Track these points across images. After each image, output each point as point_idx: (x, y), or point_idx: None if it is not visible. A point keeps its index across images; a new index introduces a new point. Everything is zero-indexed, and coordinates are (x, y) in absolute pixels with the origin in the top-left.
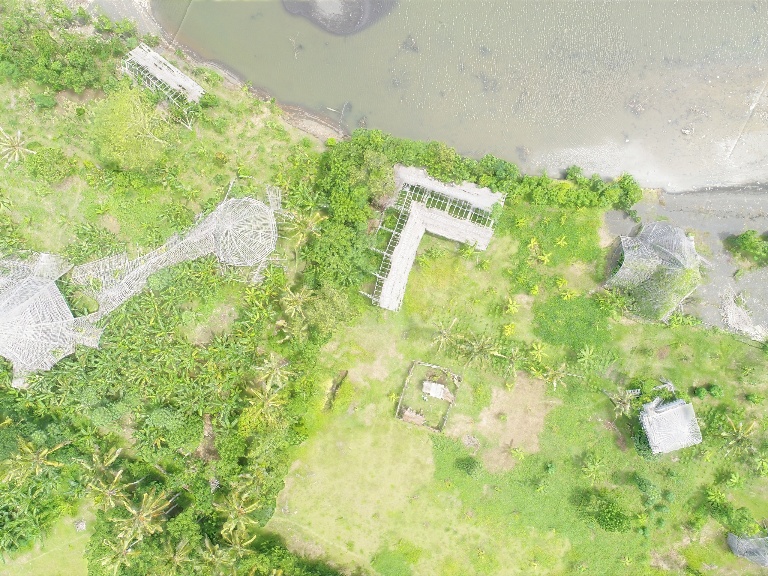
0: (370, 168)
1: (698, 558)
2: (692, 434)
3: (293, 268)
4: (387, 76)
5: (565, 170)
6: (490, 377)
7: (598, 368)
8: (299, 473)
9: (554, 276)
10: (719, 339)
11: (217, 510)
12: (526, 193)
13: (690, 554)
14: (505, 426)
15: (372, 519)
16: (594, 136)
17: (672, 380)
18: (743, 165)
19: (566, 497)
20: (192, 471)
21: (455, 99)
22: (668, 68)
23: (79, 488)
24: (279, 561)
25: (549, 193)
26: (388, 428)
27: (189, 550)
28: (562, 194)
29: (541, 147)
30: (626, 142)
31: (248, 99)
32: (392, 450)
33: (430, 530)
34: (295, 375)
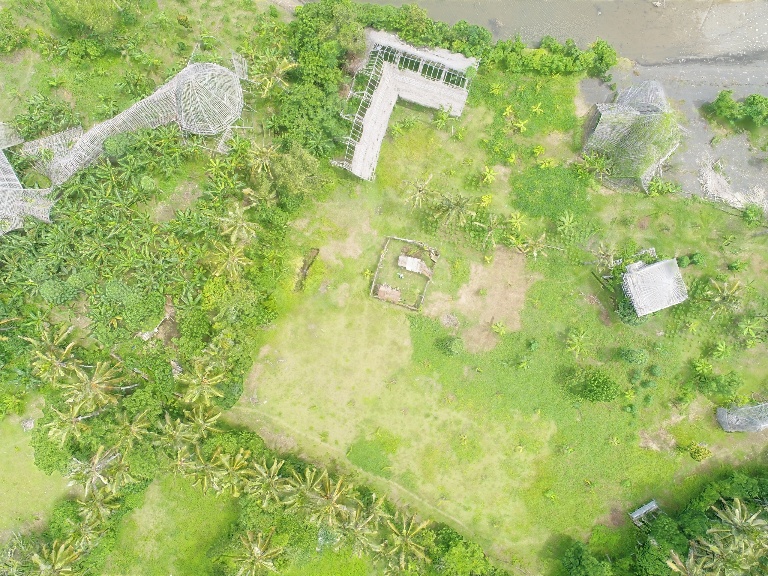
0: (340, 25)
1: (688, 436)
2: (677, 288)
3: (260, 142)
4: None
5: (538, 43)
6: (468, 252)
7: (578, 240)
8: (268, 359)
9: (531, 146)
10: (699, 208)
11: (179, 399)
12: (500, 60)
13: (679, 432)
14: (485, 303)
15: (347, 407)
16: (566, 9)
17: None
18: (714, 37)
19: (550, 376)
20: (151, 346)
21: None
22: None
23: (26, 377)
24: (247, 443)
25: (523, 58)
26: (363, 308)
27: (147, 424)
28: (536, 58)
29: (514, 20)
30: (598, 15)
31: None
32: (367, 332)
33: (409, 417)
34: (263, 248)
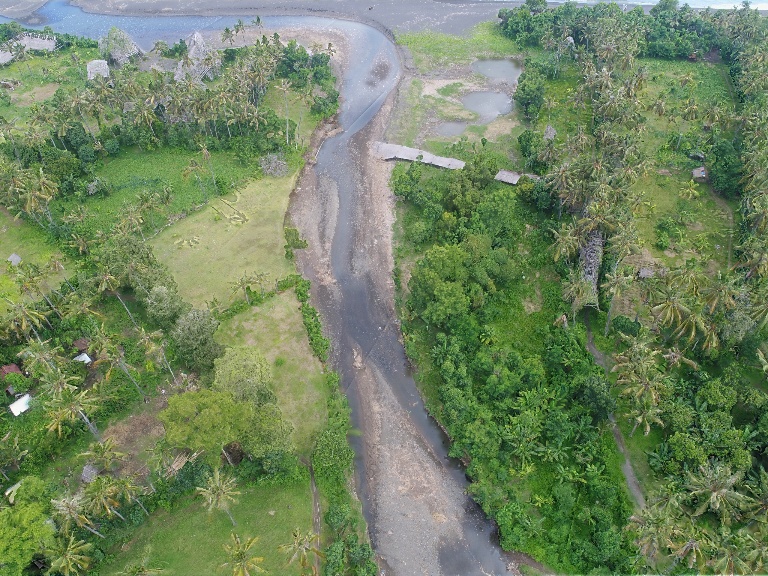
0: None
1: None
2: (100, 63)
3: None
4: None
5: None
6: (36, 84)
7: None
8: None
9: None
10: None
11: None
12: None
13: None
14: None
15: None
16: None
17: None
18: None
19: None
20: None
21: None
22: None
23: None
24: None
25: None
26: None
27: None
28: None
29: None
30: None
31: None
32: None
33: None
34: None
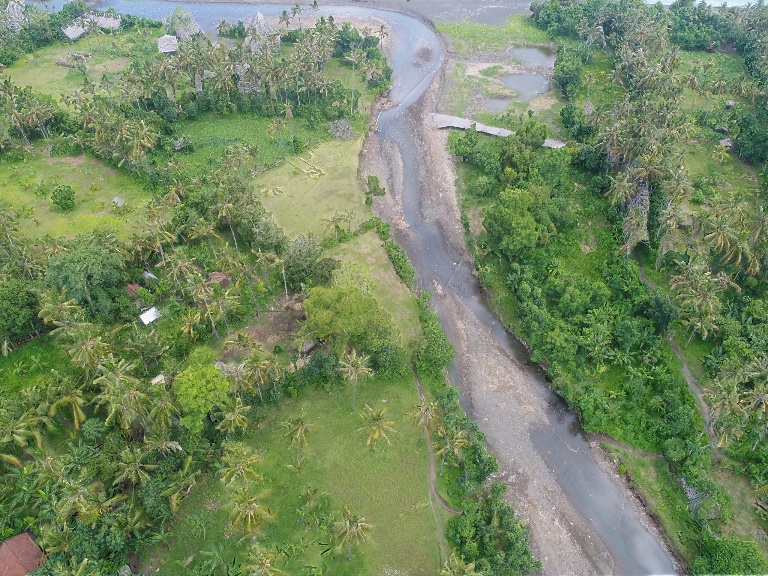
0: None
1: None
2: (171, 38)
3: None
4: None
5: None
6: None
7: None
8: None
9: None
10: None
11: None
12: None
13: None
14: None
15: None
16: None
17: None
18: None
19: None
20: None
21: None
22: None
23: None
24: None
25: None
26: (51, 67)
27: None
28: None
29: None
30: None
31: None
32: None
33: None
34: None
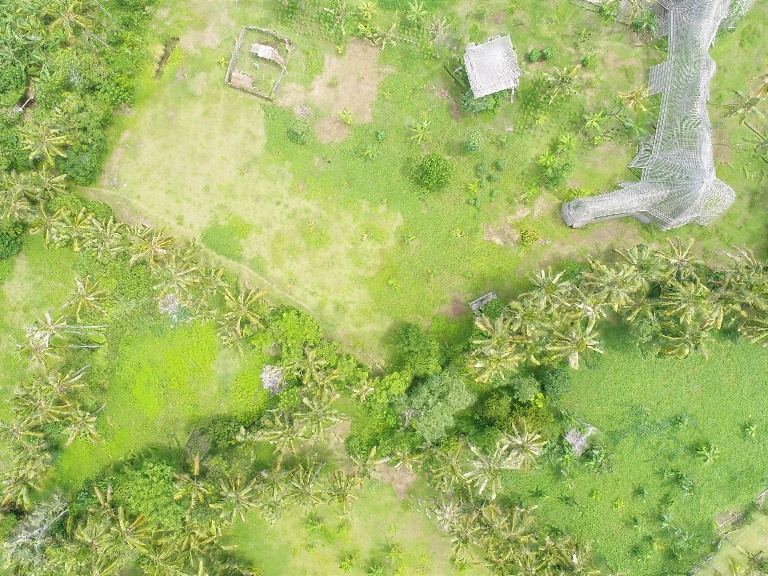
0: None
1: None
2: (507, 62)
3: None
4: None
5: None
6: (323, 44)
7: None
8: (128, 143)
9: None
10: (556, 3)
11: None
12: None
13: None
14: (337, 95)
15: (202, 192)
16: None
17: None
18: None
19: (398, 168)
20: (5, 112)
21: None
22: None
23: None
24: None
25: None
26: (219, 97)
27: None
28: None
29: None
30: None
31: None
32: (223, 120)
33: (261, 204)
34: None
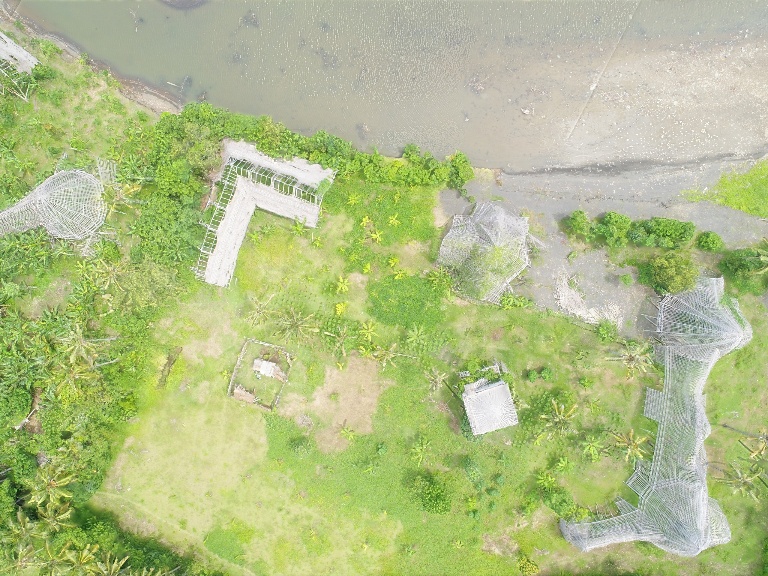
0: (192, 141)
1: (530, 543)
2: (505, 415)
3: (129, 243)
4: (228, 51)
5: None
6: (324, 356)
7: (432, 349)
8: (132, 450)
9: (388, 255)
10: (553, 322)
11: None
12: (359, 170)
13: (522, 539)
14: (338, 406)
15: (205, 497)
16: (434, 115)
17: (505, 362)
18: (583, 146)
19: (398, 479)
20: (11, 444)
21: (295, 75)
22: (509, 47)
23: None
24: (98, 536)
25: (380, 170)
26: (221, 406)
27: None
28: (392, 172)
29: (381, 125)
30: (466, 121)
31: (85, 72)
32: (225, 428)
33: (263, 510)
34: (123, 350)
